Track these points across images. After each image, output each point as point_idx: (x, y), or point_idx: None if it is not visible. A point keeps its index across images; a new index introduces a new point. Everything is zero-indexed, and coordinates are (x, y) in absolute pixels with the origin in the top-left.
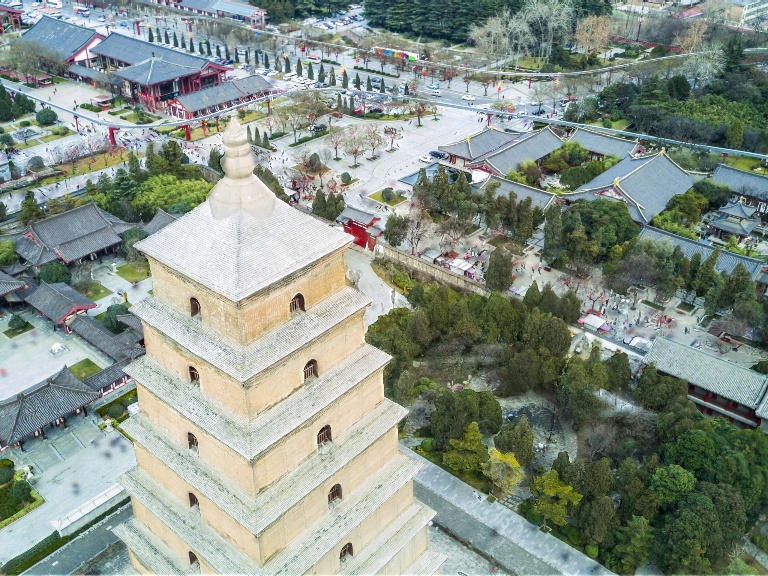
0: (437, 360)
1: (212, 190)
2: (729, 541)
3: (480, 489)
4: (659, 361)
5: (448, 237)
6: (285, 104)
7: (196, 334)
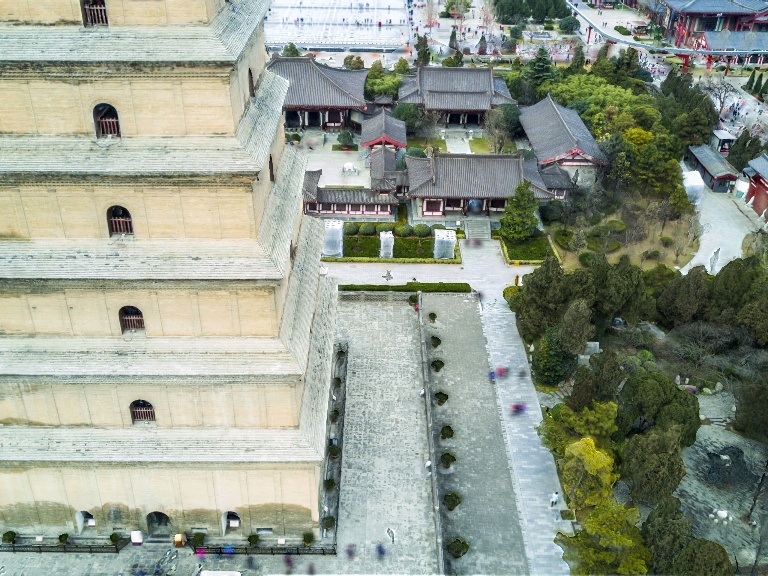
0: (681, 339)
1: None
2: None
3: (567, 495)
4: None
5: None
6: None
7: None
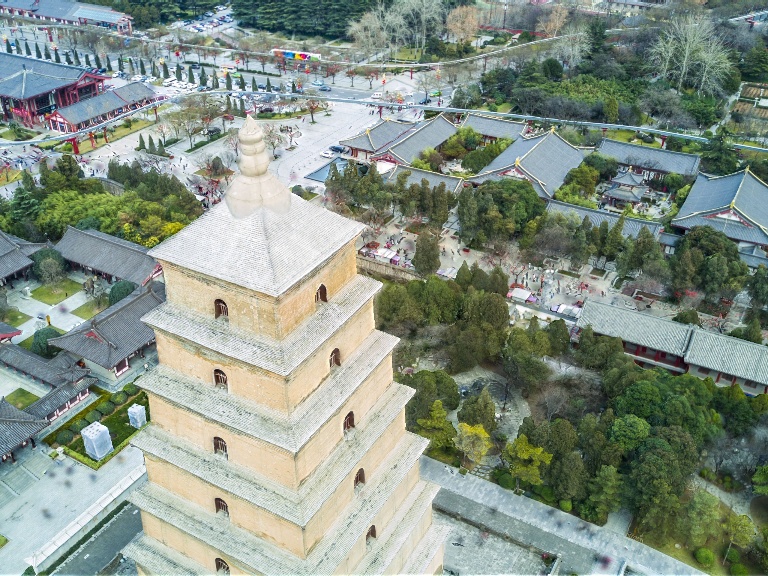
0: None
1: (228, 190)
2: (685, 477)
3: (451, 464)
4: (592, 323)
5: (369, 228)
6: (171, 110)
7: (224, 335)
